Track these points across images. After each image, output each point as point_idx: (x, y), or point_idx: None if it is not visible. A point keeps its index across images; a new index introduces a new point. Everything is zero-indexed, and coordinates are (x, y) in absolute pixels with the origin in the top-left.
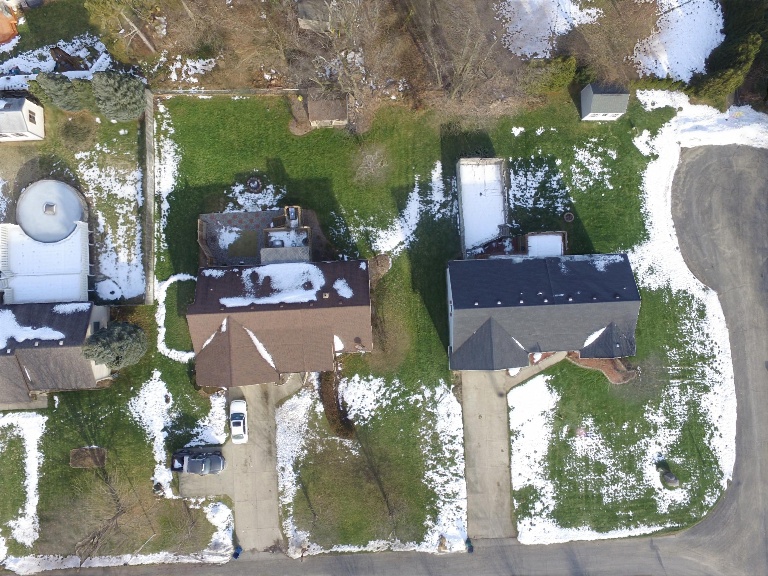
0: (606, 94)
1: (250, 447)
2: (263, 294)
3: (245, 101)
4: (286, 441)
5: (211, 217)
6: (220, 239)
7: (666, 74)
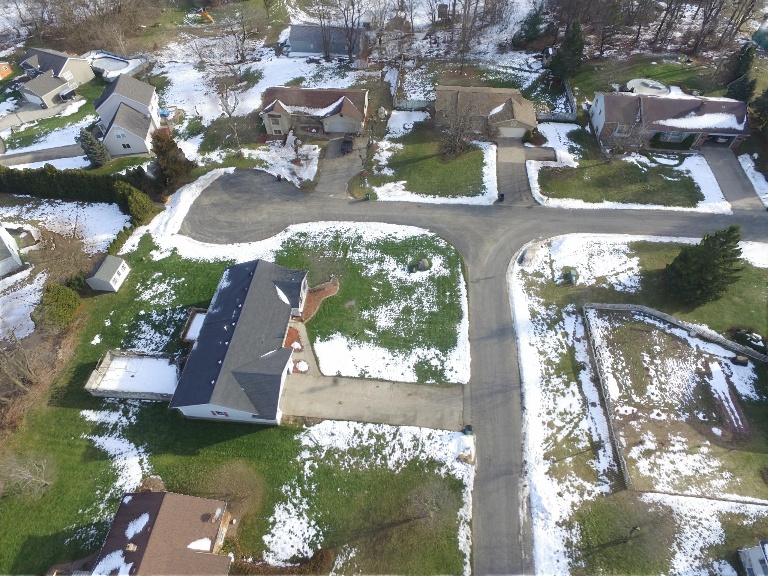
0: (99, 269)
1: None
2: None
3: None
4: None
5: None
6: None
7: None
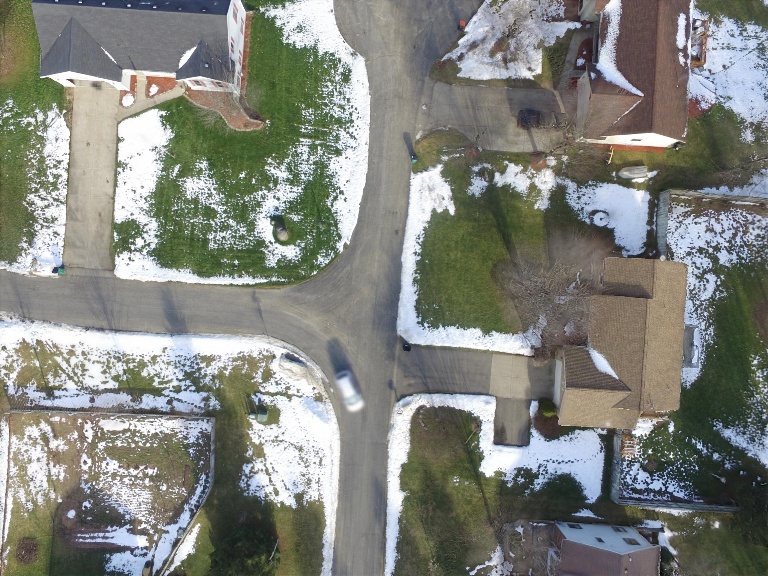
0: None
1: None
2: None
3: None
4: None
5: None
6: None
7: None
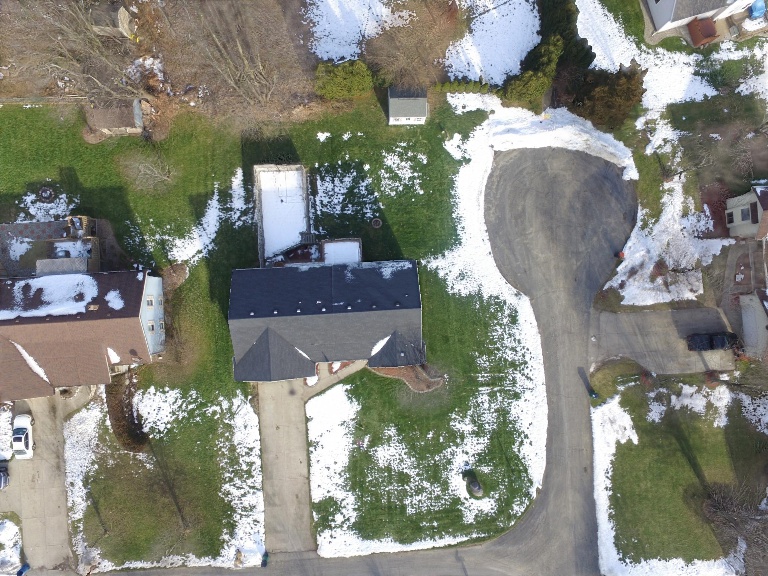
0: (402, 98)
1: (37, 462)
2: (31, 307)
3: (37, 109)
4: (75, 456)
5: (2, 228)
6: (11, 250)
7: (479, 77)
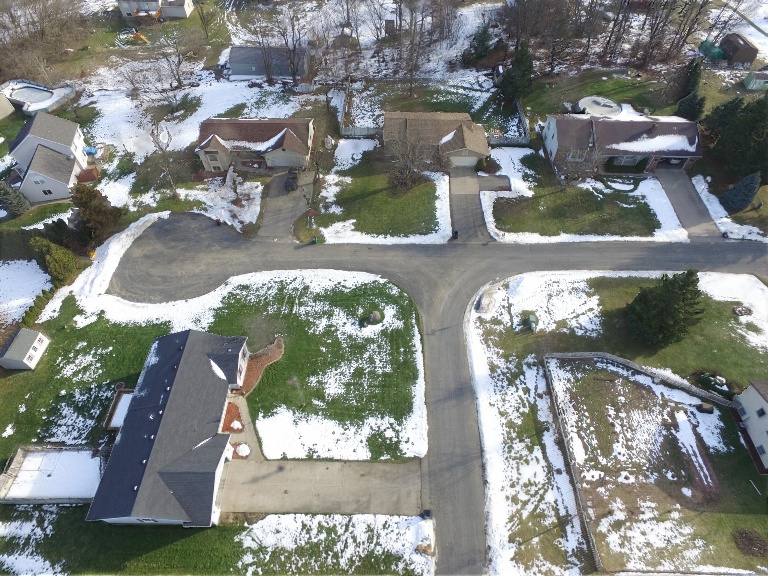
0: (10, 347)
1: None
2: None
3: None
4: None
5: None
6: None
7: None
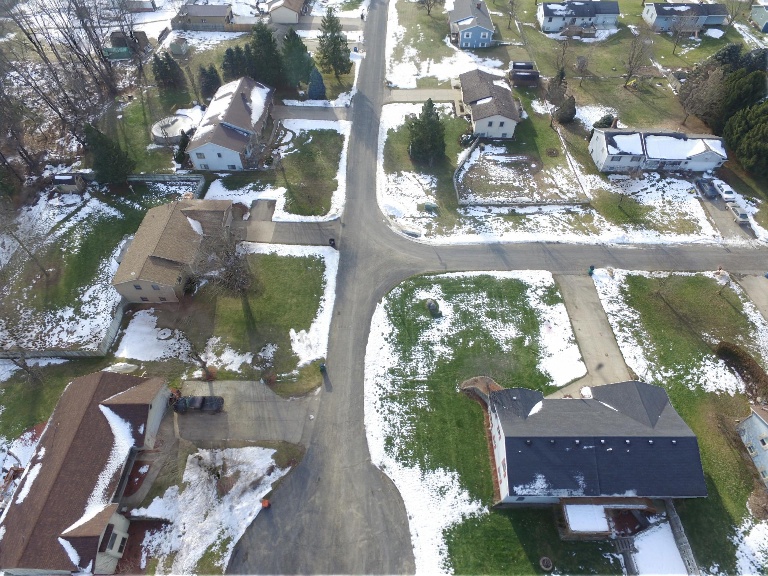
0: None
1: None
2: None
3: None
4: None
5: None
6: None
7: None
